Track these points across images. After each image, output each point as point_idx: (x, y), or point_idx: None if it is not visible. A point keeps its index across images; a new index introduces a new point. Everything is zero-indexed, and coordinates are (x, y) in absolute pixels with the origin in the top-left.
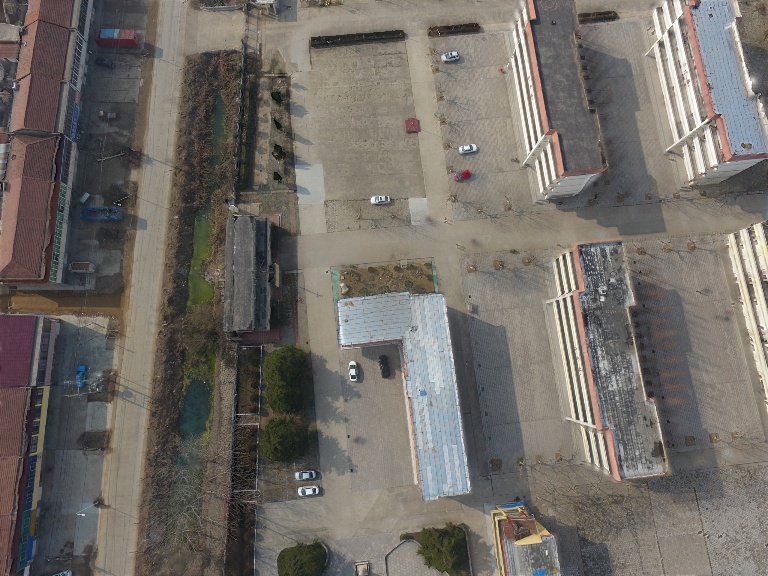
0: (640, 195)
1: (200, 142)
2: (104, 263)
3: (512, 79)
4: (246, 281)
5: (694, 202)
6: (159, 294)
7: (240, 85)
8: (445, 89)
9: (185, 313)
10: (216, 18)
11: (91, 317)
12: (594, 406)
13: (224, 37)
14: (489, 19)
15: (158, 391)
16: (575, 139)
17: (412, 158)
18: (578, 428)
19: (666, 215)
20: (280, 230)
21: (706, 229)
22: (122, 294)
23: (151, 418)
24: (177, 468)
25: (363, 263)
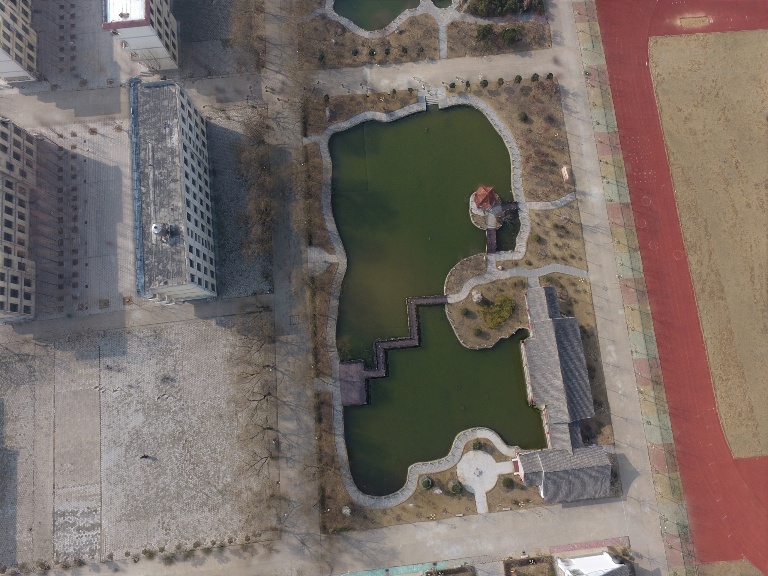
0: (102, 80)
1: None
2: None
3: None
4: None
5: None
6: None
7: None
8: None
9: None
10: None
11: None
12: None
13: None
14: None
15: None
16: None
17: None
18: None
19: (123, 98)
20: None
21: None
22: None
23: None
24: None
25: None
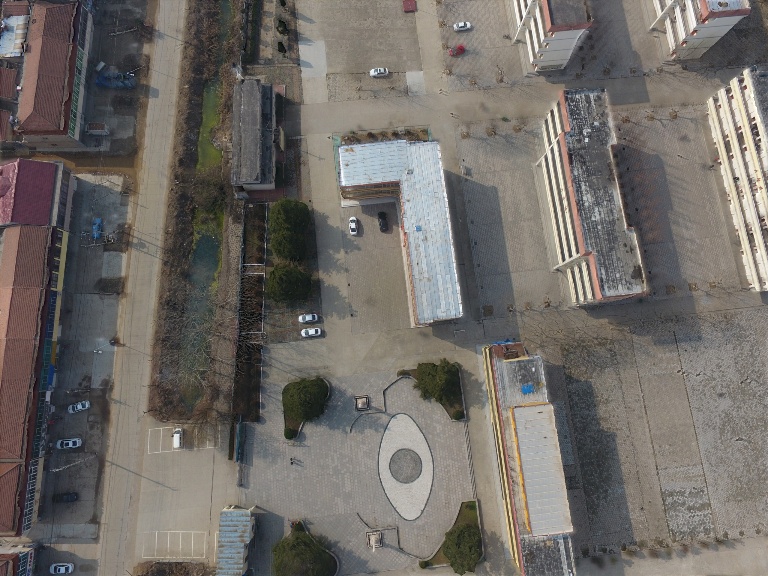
0: (625, 69)
1: (208, 20)
2: (118, 127)
3: None
4: (253, 137)
5: (676, 75)
6: (170, 156)
7: None
8: None
9: (195, 175)
10: None
11: (106, 176)
12: (578, 234)
13: None
14: None
15: (170, 242)
16: None
17: (409, 35)
18: (565, 275)
19: (650, 87)
20: (284, 99)
21: (687, 100)
22: (135, 156)
23: (163, 266)
24: (188, 314)
25: (363, 130)
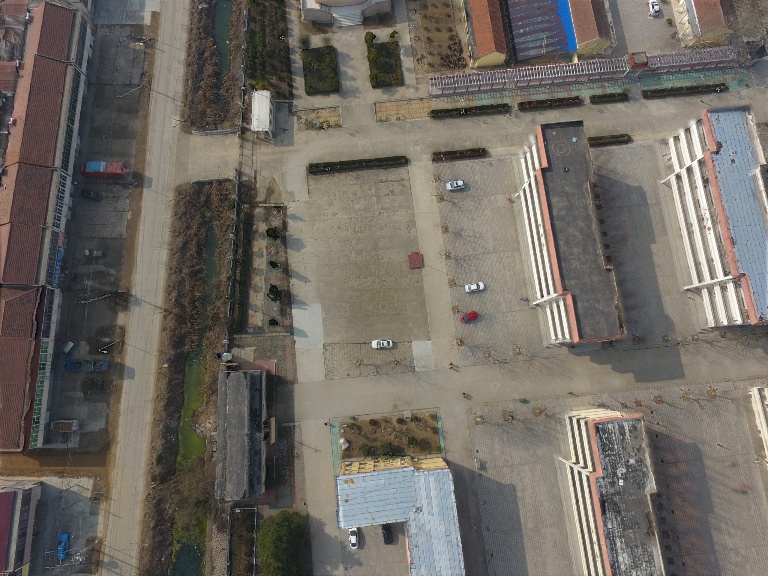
0: (657, 337)
1: (191, 280)
2: (89, 418)
3: (521, 212)
4: (239, 445)
5: (714, 345)
6: (147, 451)
7: (233, 222)
8: (450, 220)
9: (175, 470)
10: (208, 143)
11: (74, 478)
12: None
13: (217, 164)
14: (496, 142)
15: (146, 561)
16: (590, 301)
17: (415, 296)
18: None
19: (685, 359)
20: (276, 378)
21: (727, 375)
22: (108, 452)
23: None
24: None
25: (364, 414)
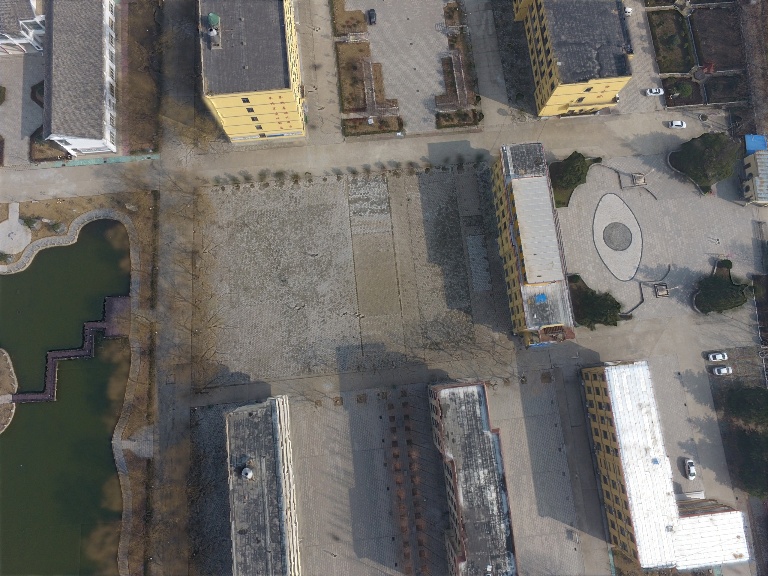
0: None
1: None
2: None
3: None
4: None
5: None
6: None
7: None
8: None
9: None
10: None
11: None
12: None
13: None
14: None
15: None
16: None
17: None
18: None
19: None
20: None
21: None
22: None
23: None
24: None
25: None
